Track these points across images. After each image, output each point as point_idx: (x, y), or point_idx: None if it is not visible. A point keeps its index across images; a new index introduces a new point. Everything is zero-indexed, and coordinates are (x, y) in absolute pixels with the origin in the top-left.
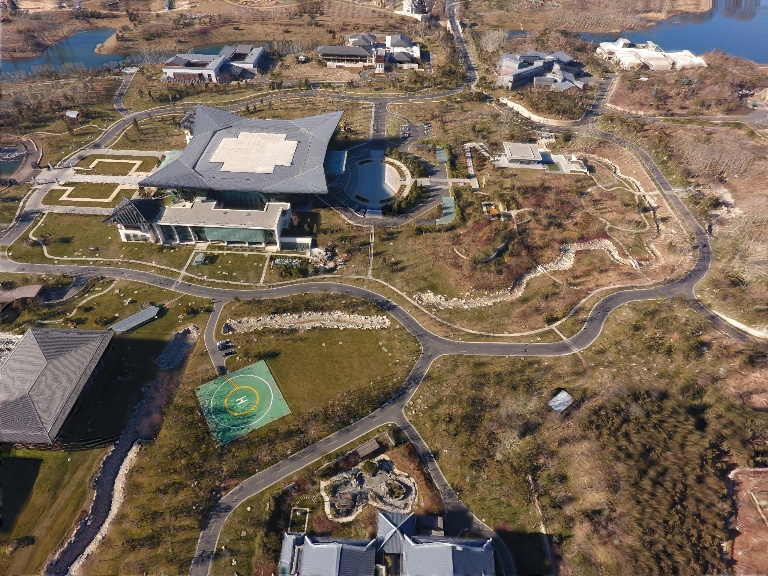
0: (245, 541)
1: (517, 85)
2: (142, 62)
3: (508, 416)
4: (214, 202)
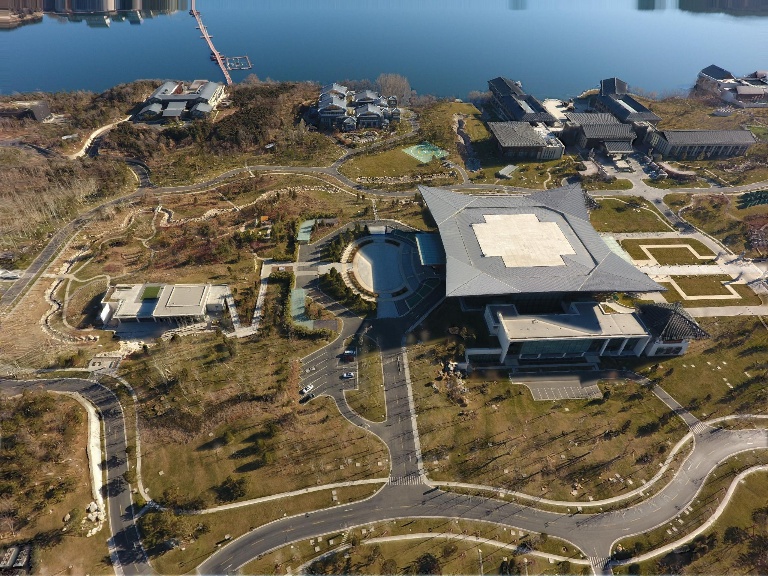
0: (403, 127)
1: None
2: None
3: (299, 140)
4: None
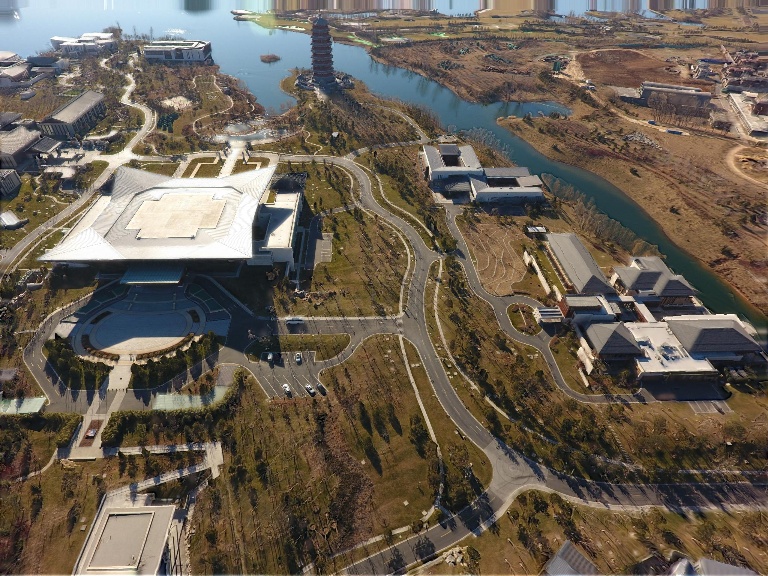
0: None
1: None
2: None
3: None
4: None
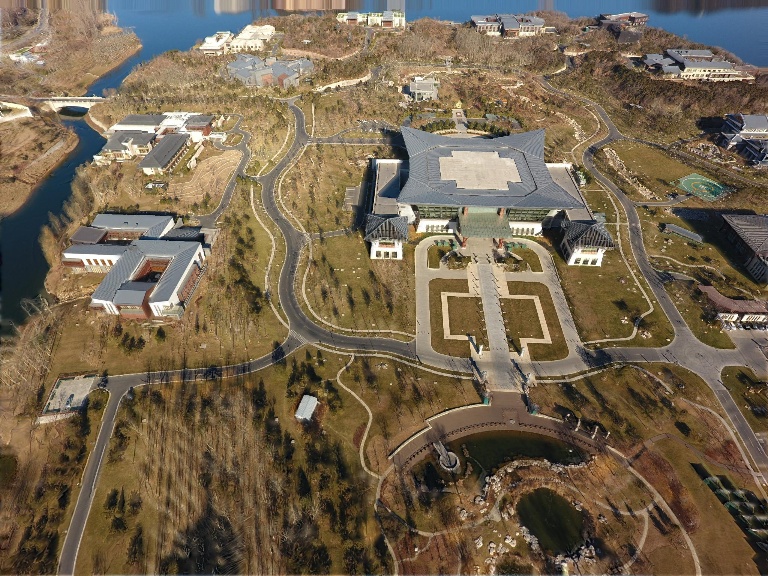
0: None
1: None
2: None
3: (656, 115)
4: None
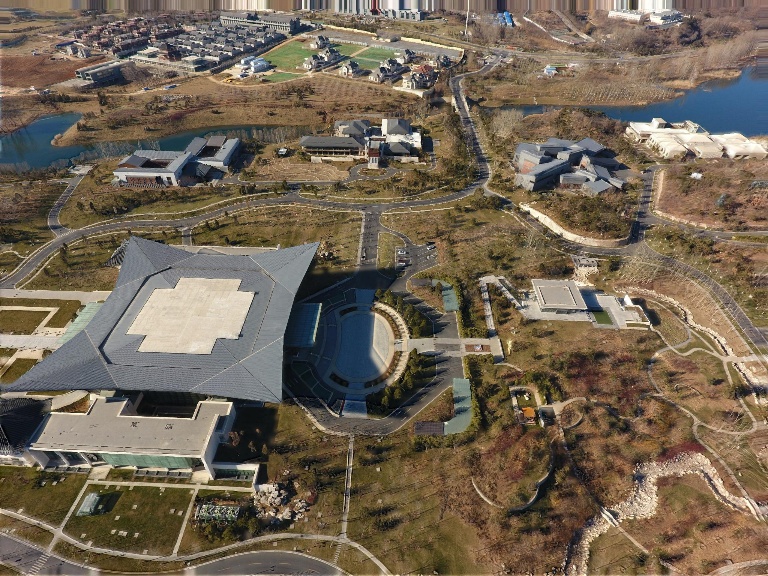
0: None
1: (540, 185)
2: (99, 157)
3: None
4: (124, 401)
